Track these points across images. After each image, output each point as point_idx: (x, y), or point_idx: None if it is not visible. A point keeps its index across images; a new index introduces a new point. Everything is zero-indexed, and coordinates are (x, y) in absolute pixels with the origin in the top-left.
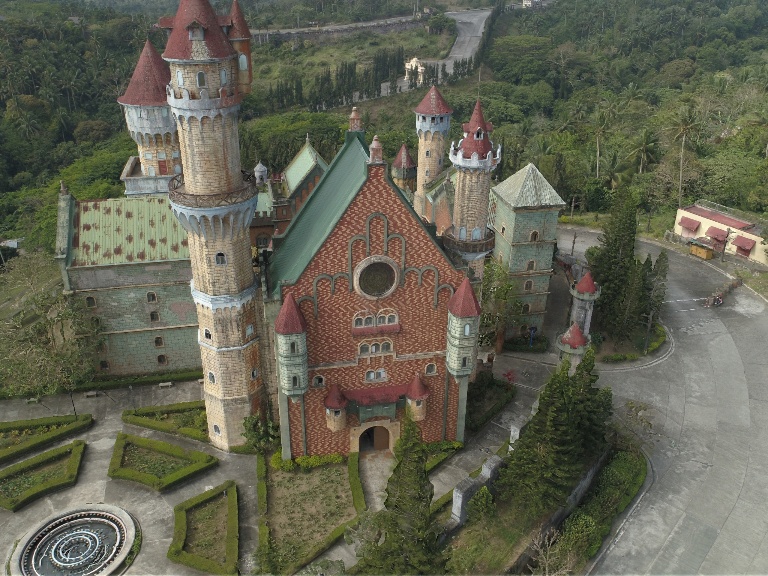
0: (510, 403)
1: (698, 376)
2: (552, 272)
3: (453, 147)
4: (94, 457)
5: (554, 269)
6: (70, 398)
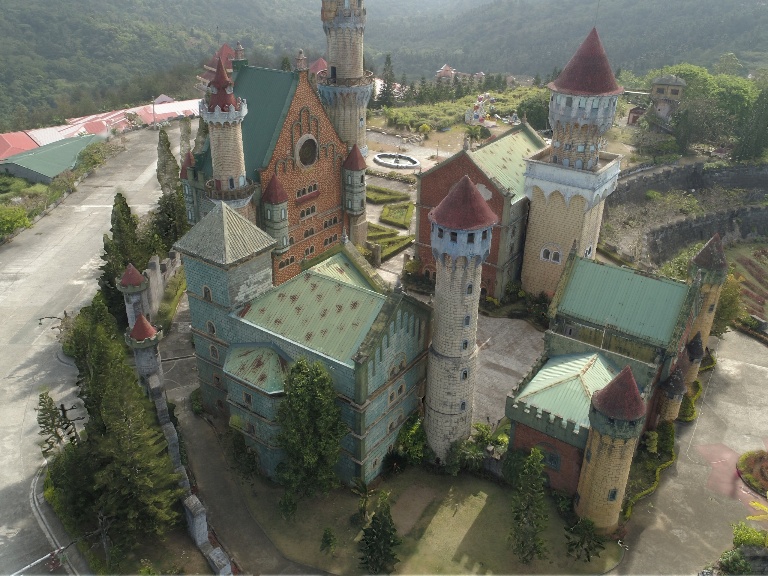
0: None
1: (3, 459)
2: (192, 330)
3: (240, 98)
4: (394, 228)
5: (237, 467)
6: None
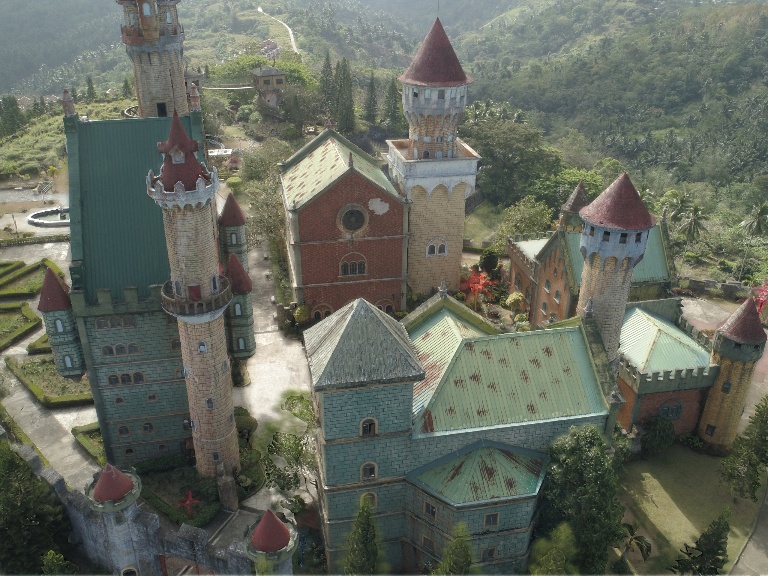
0: (172, 523)
1: None
2: (327, 492)
3: None
4: None
5: None
6: (268, 268)
